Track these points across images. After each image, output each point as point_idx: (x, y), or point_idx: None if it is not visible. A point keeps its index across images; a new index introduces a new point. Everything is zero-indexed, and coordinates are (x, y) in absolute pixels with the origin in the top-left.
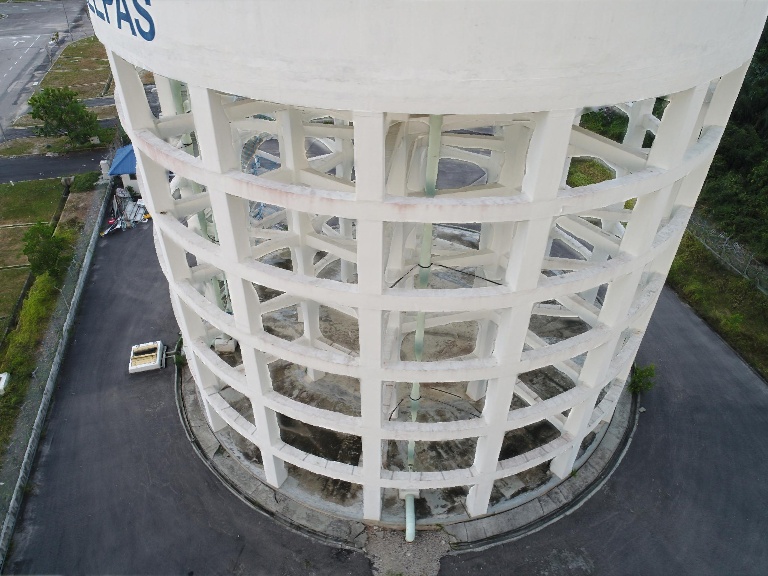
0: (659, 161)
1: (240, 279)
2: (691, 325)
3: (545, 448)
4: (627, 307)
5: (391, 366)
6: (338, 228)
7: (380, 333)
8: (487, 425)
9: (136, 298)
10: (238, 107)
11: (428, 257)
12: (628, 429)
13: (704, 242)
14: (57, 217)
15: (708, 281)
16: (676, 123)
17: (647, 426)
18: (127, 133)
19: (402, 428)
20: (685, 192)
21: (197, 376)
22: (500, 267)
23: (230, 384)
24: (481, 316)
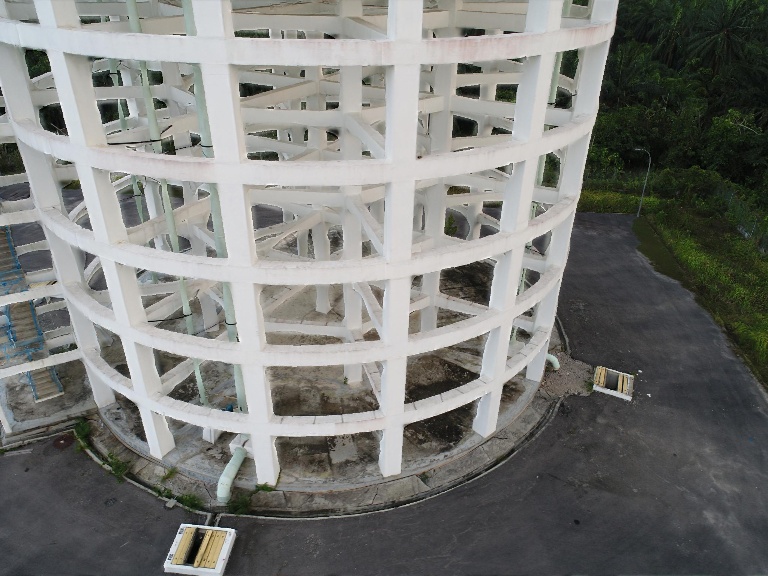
0: None
1: (538, 158)
2: None
3: (535, 252)
4: None
5: None
6: None
7: None
8: None
9: (14, 568)
10: None
11: None
12: None
13: None
14: None
15: None
16: None
17: None
18: (384, 60)
19: None
20: None
21: (393, 404)
22: None
23: (479, 333)
24: None
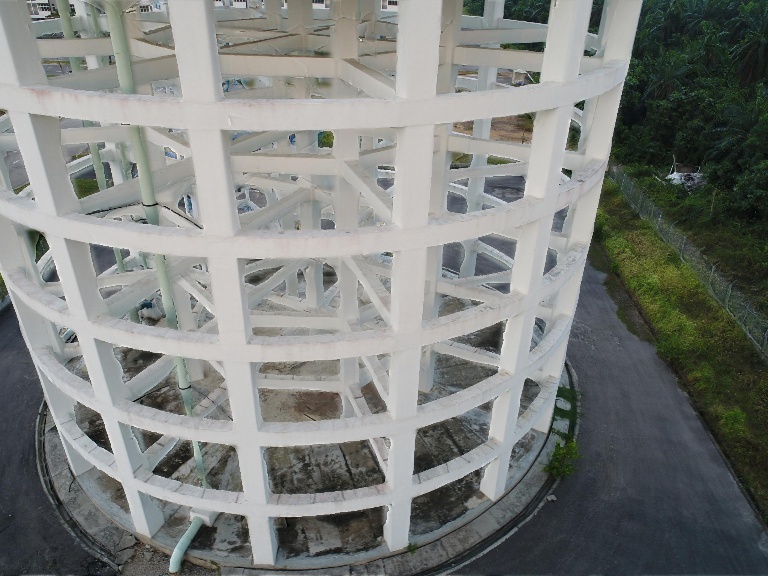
0: (402, 89)
1: None
2: (678, 417)
3: (345, 494)
4: (415, 307)
5: (101, 321)
6: None
7: (73, 270)
8: (231, 430)
9: None
10: (64, 42)
11: (146, 192)
12: (521, 517)
13: (746, 329)
14: None
15: (732, 373)
16: (405, 30)
17: (548, 519)
18: None
19: (136, 411)
20: (533, 178)
21: None
22: (343, 263)
23: None
24: (335, 326)
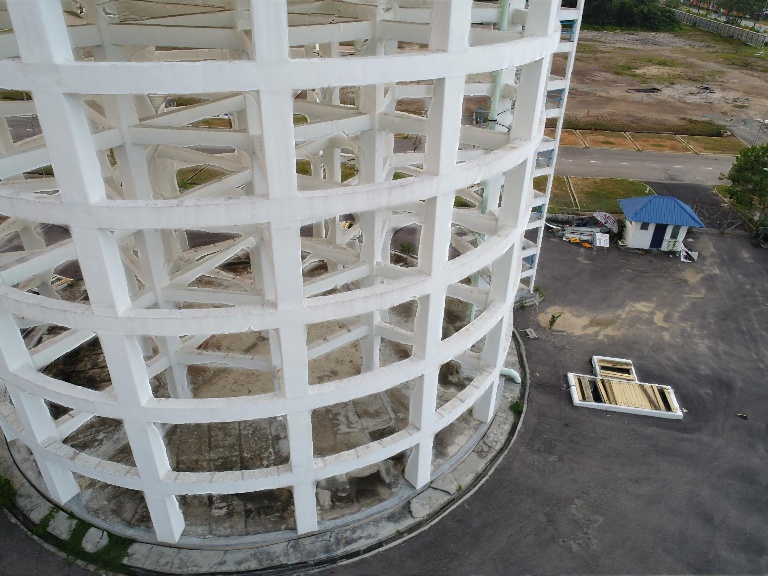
0: None
1: None
2: None
3: None
4: None
5: None
6: (520, 348)
7: None
8: None
9: None
10: None
11: None
12: None
13: None
14: (590, 211)
15: None
16: None
17: None
18: None
19: None
20: None
21: None
22: None
23: None
24: None
